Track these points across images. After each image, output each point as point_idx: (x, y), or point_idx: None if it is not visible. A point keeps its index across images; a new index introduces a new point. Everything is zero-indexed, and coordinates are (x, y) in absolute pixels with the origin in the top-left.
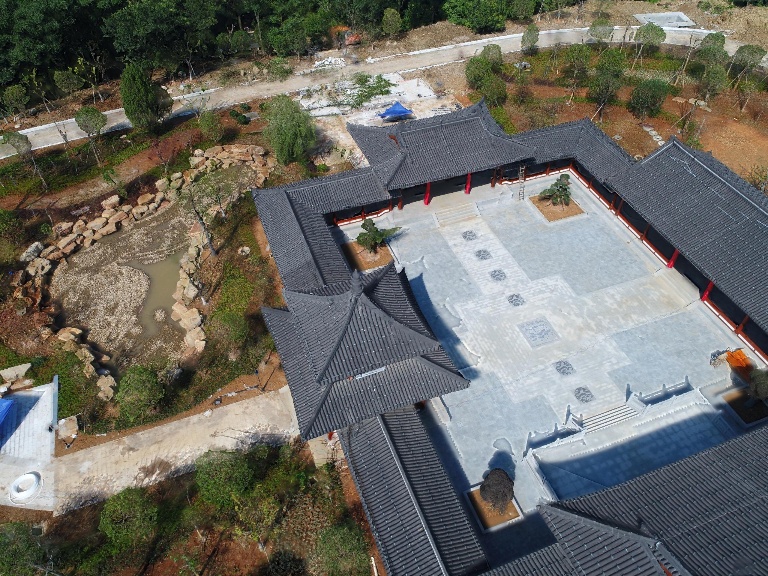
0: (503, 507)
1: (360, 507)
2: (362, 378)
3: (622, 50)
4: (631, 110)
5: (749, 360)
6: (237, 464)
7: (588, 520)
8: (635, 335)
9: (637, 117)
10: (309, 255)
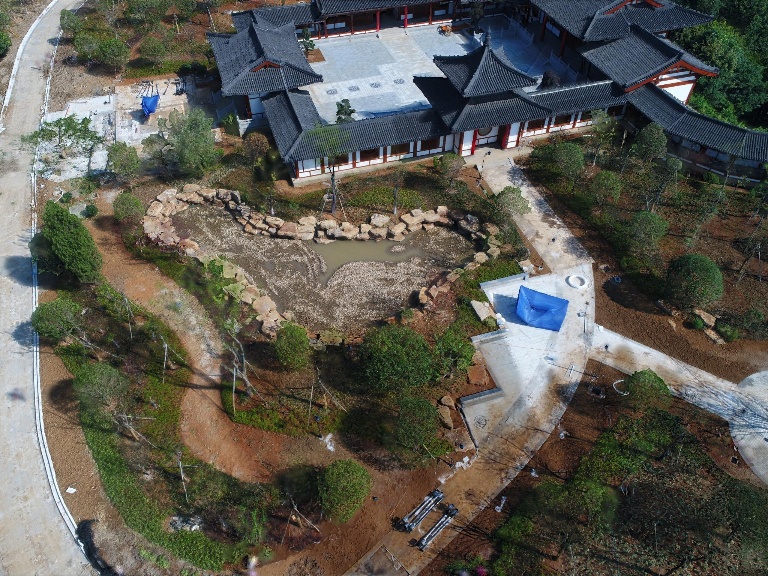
0: (557, 83)
1: (556, 140)
2: None
3: (106, 2)
4: (204, 12)
5: None
6: None
7: None
8: (429, 51)
9: (214, 12)
10: (389, 119)
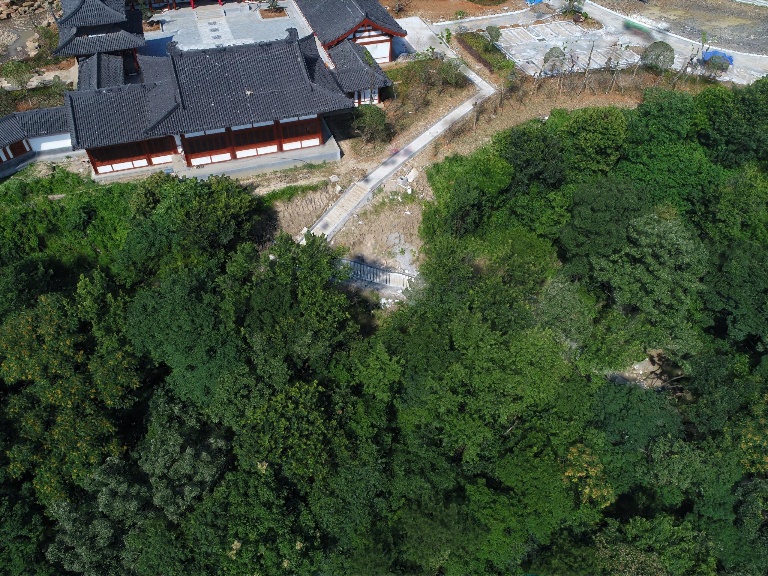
0: None
1: None
2: (92, 37)
3: None
4: None
5: (329, 67)
6: (22, 65)
7: (151, 57)
8: None
9: None
10: None
